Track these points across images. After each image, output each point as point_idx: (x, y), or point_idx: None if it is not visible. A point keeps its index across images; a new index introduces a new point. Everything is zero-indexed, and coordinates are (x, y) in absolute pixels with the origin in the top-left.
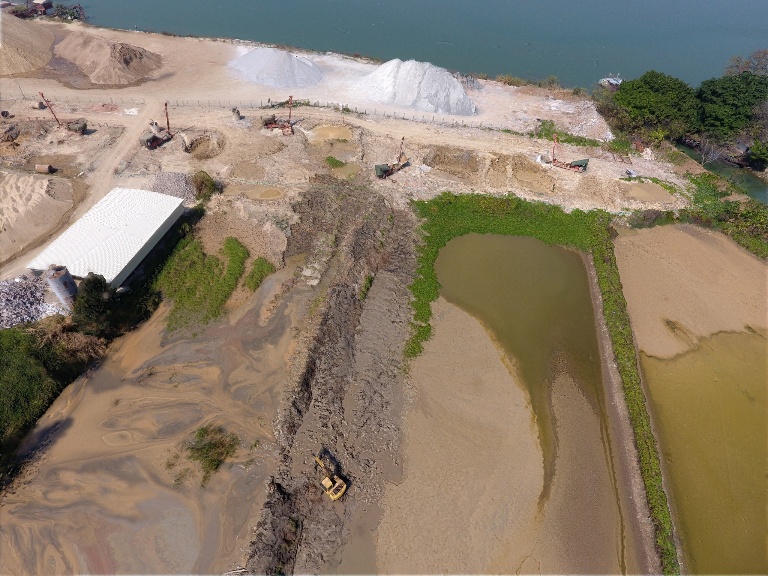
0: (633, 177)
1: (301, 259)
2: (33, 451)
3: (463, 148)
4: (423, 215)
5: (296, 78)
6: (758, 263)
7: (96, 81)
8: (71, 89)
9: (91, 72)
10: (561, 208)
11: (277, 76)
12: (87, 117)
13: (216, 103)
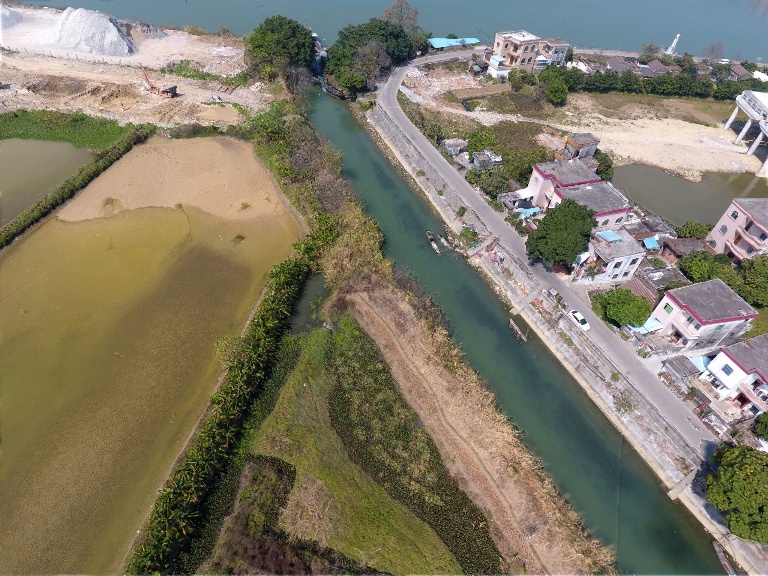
0: (214, 102)
1: None
2: None
3: (80, 79)
4: None
5: None
6: (256, 164)
7: None
8: None
9: None
10: (117, 122)
11: None
12: None
13: None
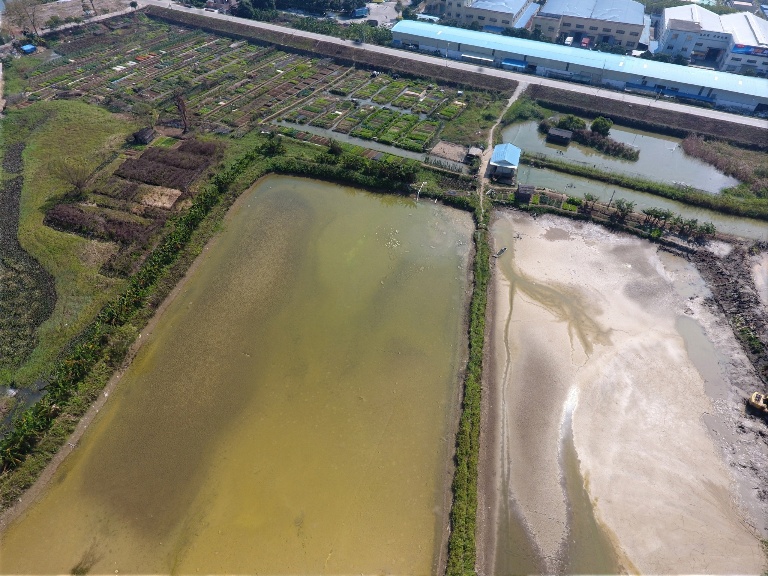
0: None
1: None
2: None
3: None
4: None
5: None
6: None
7: None
8: None
9: None
10: None
11: None
12: None
13: None
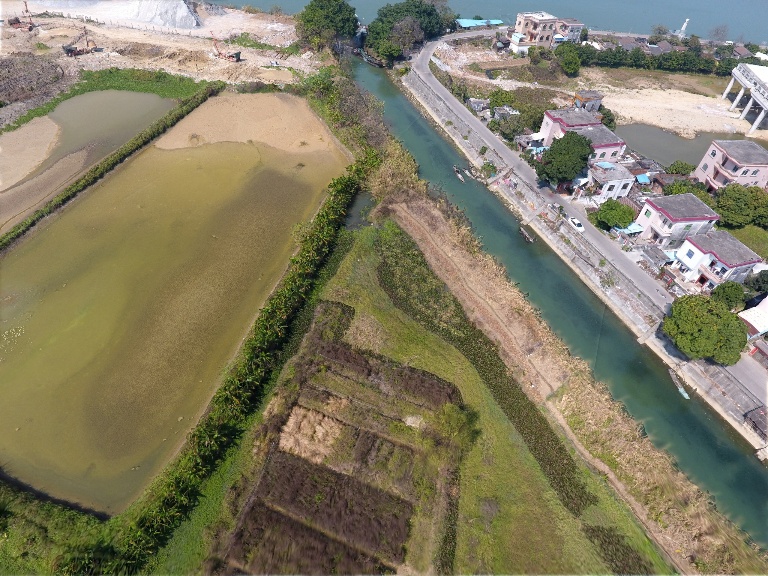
0: None
1: None
2: None
3: (159, 45)
4: (85, 79)
5: (69, 1)
6: (310, 114)
7: None
8: None
9: None
10: (193, 79)
11: None
12: None
13: None
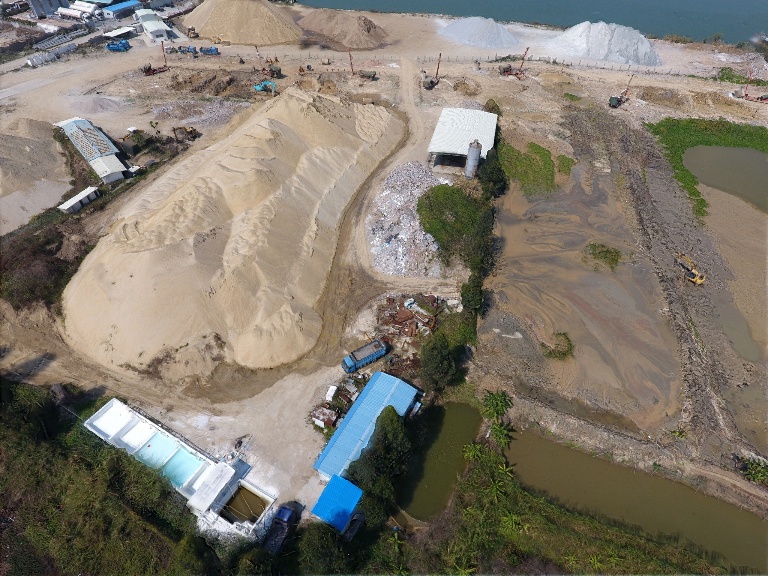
0: None
1: (588, 157)
2: (494, 251)
3: (664, 88)
4: (656, 133)
5: (502, 40)
6: None
7: (350, 45)
8: (336, 51)
9: (343, 39)
10: (766, 128)
11: (487, 39)
12: (365, 69)
13: (451, 59)
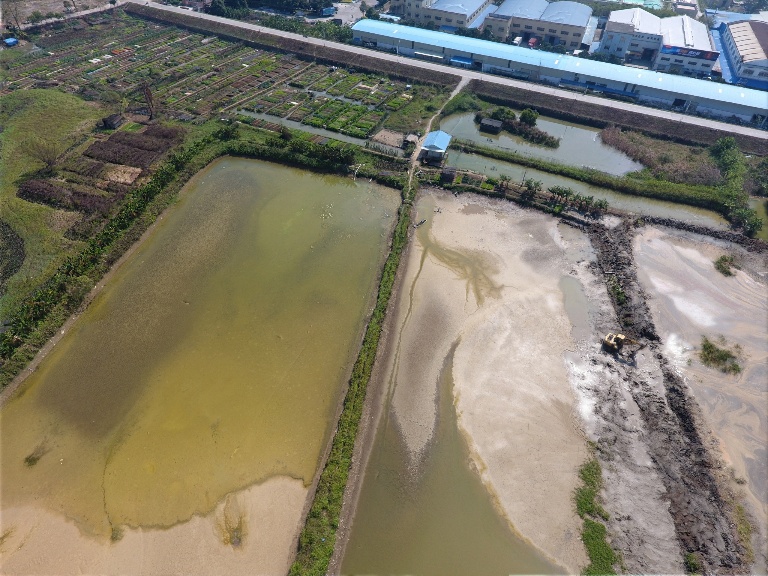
0: None
1: None
2: None
3: None
4: None
5: None
6: None
7: None
8: None
9: None
10: None
11: None
12: None
13: None
